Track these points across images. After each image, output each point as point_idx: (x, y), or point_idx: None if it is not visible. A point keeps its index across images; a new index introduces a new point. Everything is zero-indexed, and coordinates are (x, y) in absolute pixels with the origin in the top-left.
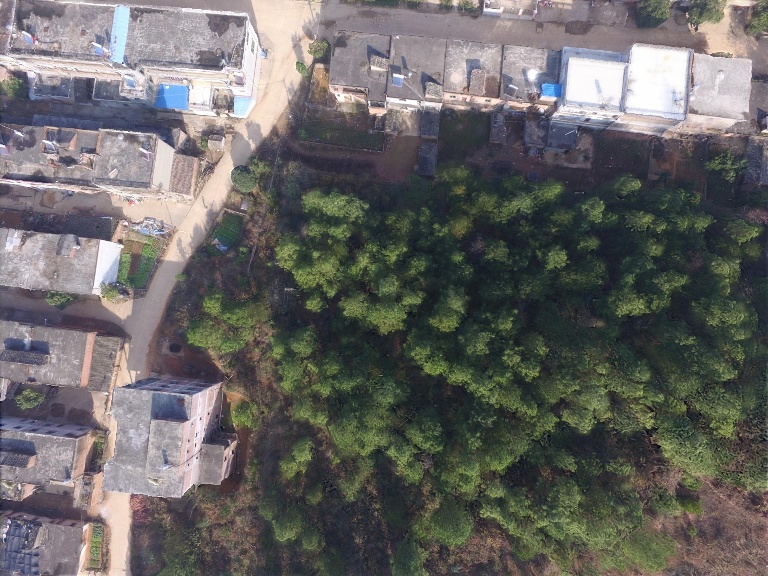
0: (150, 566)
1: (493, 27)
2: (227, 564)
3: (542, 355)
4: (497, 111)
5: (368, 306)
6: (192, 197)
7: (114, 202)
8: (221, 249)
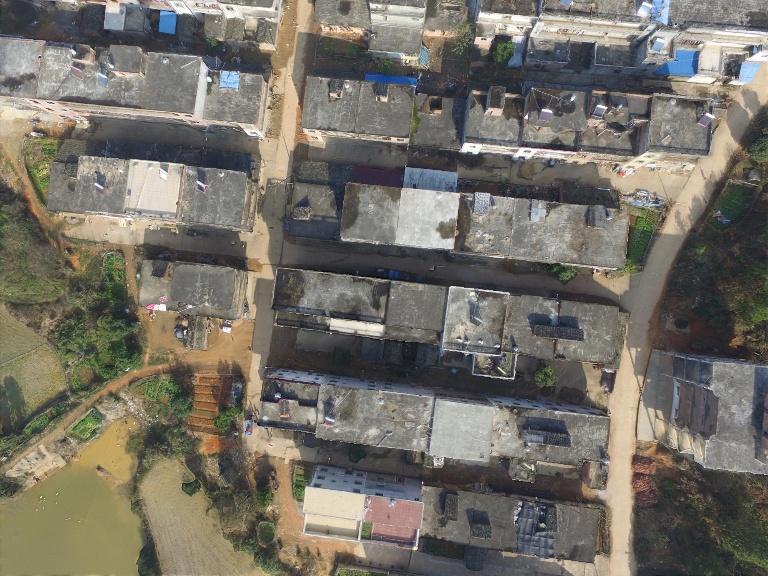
0: (657, 548)
1: None
2: None
3: None
4: None
5: None
6: (692, 168)
7: (601, 173)
8: (723, 222)
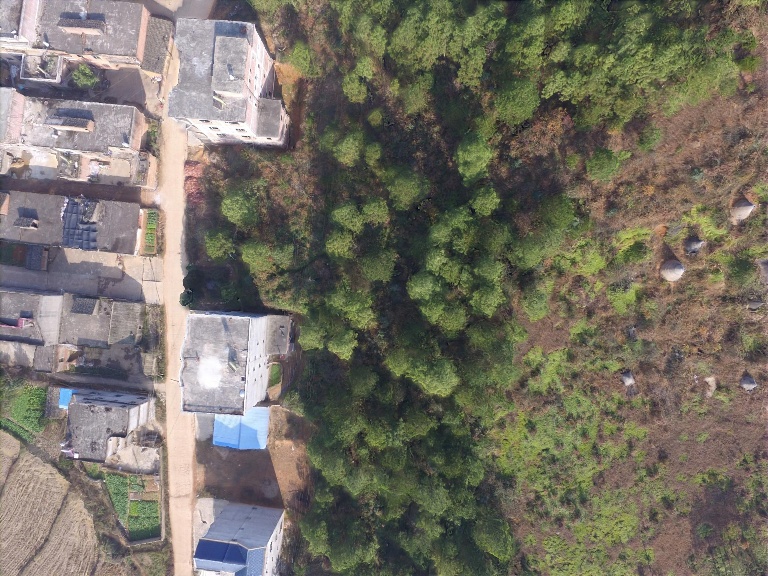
0: (205, 247)
1: None
2: (285, 219)
3: None
4: None
5: None
6: None
7: None
8: None
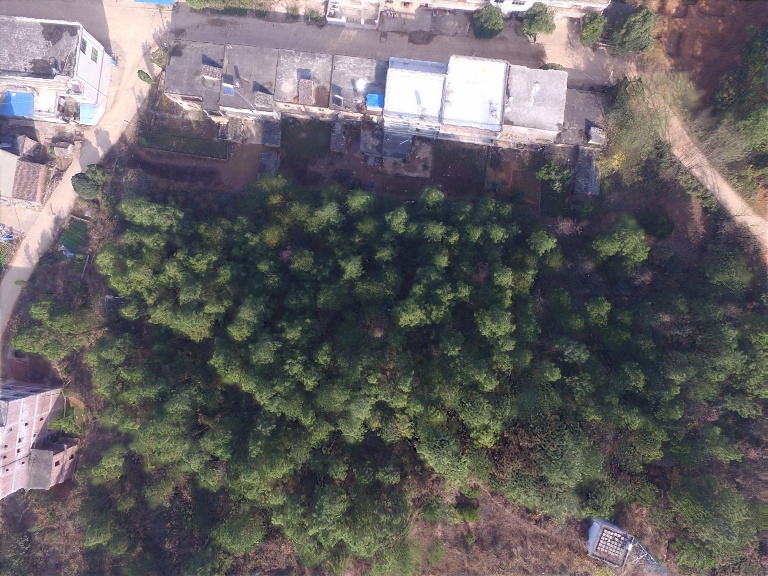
0: None
1: (338, 36)
2: (58, 568)
3: (323, 364)
4: (335, 120)
5: (171, 314)
6: (39, 203)
7: None
8: (67, 255)
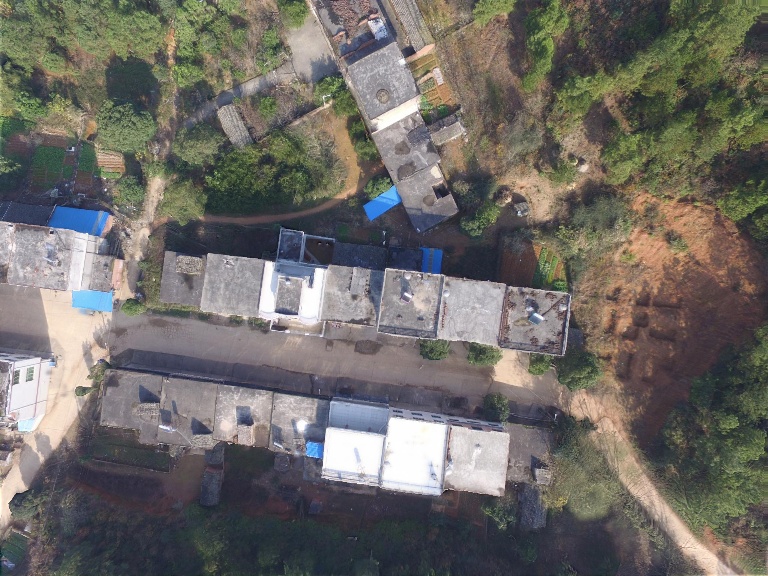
0: None
1: (283, 343)
2: None
3: None
4: None
5: None
6: None
7: None
8: (9, 566)
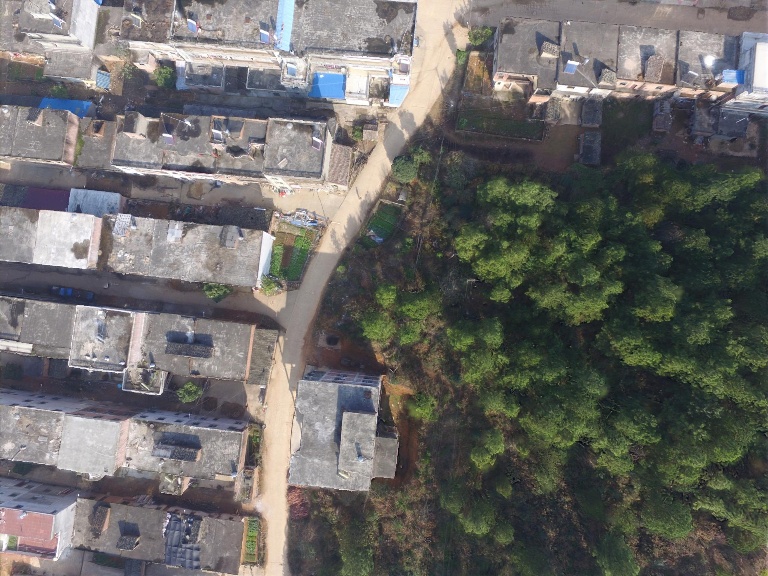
0: (309, 560)
1: (652, 13)
2: (399, 558)
3: (767, 345)
4: (664, 99)
5: (570, 296)
6: (346, 188)
7: (264, 193)
8: (376, 240)
